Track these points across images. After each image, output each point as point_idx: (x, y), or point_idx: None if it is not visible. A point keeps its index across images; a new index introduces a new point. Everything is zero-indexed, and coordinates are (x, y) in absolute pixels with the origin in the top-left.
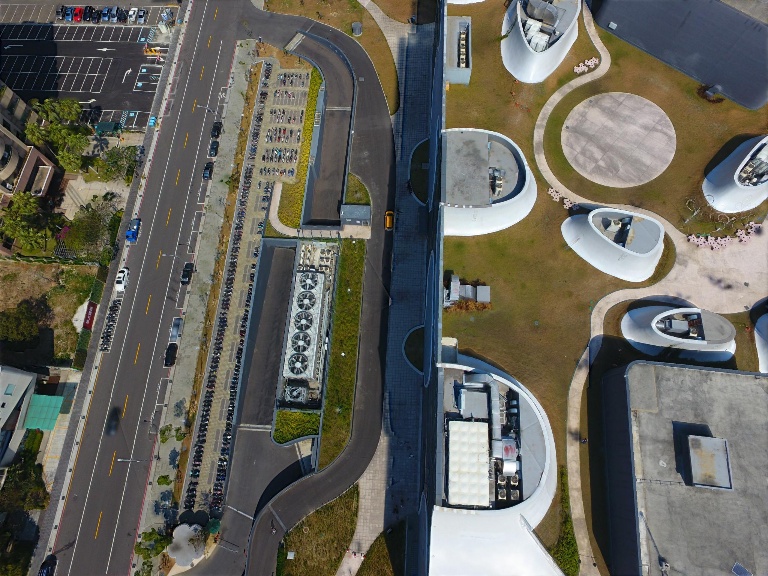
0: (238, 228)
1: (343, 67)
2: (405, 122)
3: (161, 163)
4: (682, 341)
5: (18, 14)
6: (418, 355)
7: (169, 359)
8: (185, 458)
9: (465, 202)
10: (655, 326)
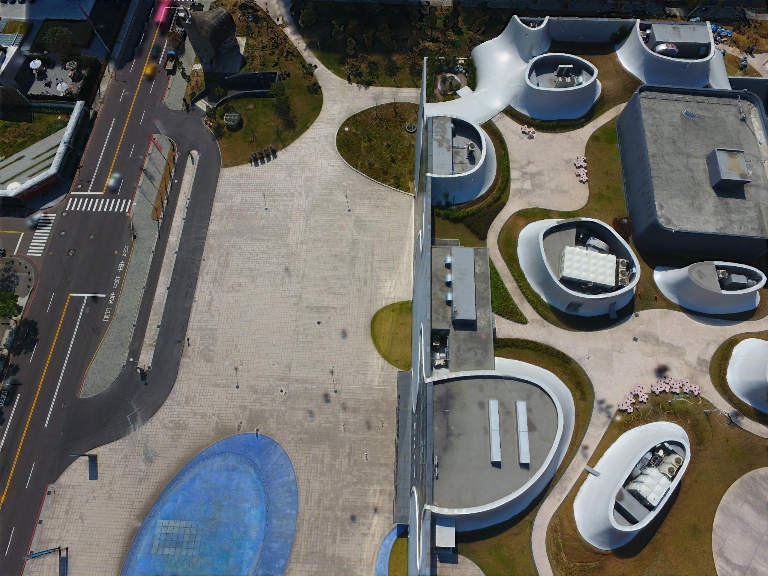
0: None
1: None
2: None
3: None
4: (737, 264)
5: None
6: None
7: None
8: None
9: None
10: (763, 277)
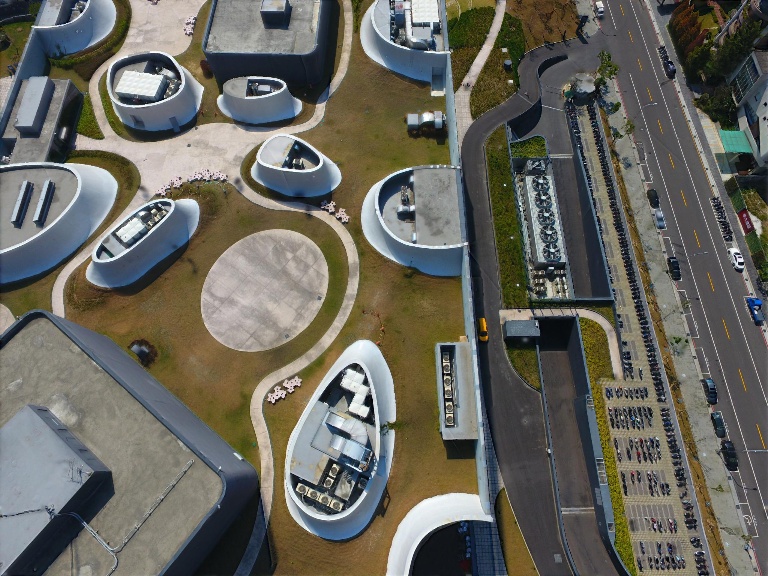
0: (644, 318)
1: None
2: None
3: None
4: (266, 77)
5: None
6: None
7: (653, 193)
8: (607, 131)
9: (437, 171)
10: (284, 85)
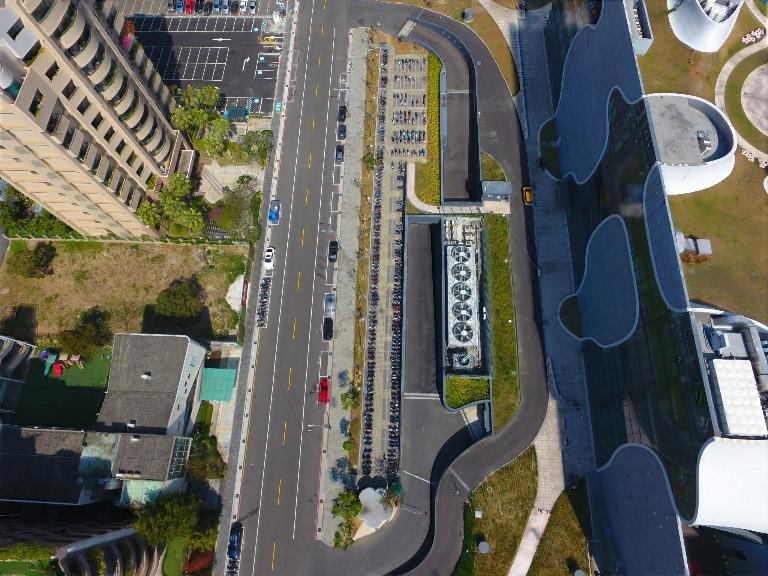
0: (377, 207)
1: (456, 52)
2: (528, 103)
3: (292, 147)
4: None
5: (128, 7)
6: (574, 322)
7: (328, 332)
8: (357, 426)
9: (679, 161)
10: None
